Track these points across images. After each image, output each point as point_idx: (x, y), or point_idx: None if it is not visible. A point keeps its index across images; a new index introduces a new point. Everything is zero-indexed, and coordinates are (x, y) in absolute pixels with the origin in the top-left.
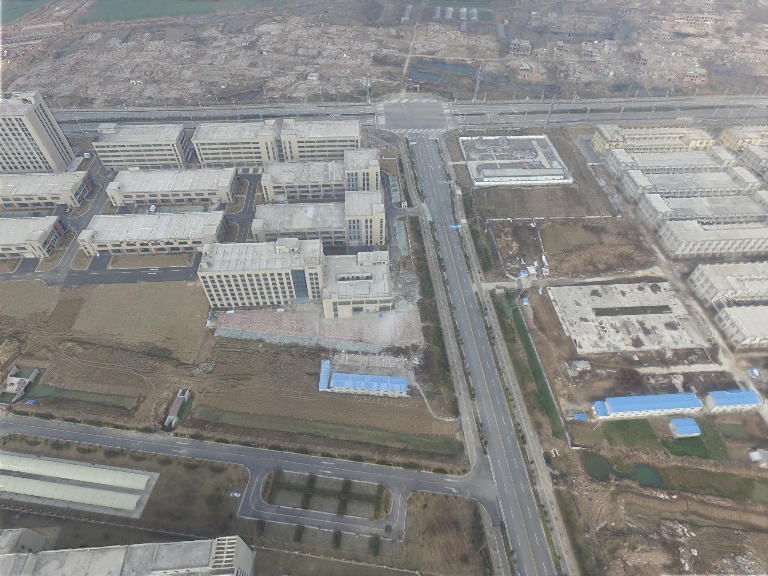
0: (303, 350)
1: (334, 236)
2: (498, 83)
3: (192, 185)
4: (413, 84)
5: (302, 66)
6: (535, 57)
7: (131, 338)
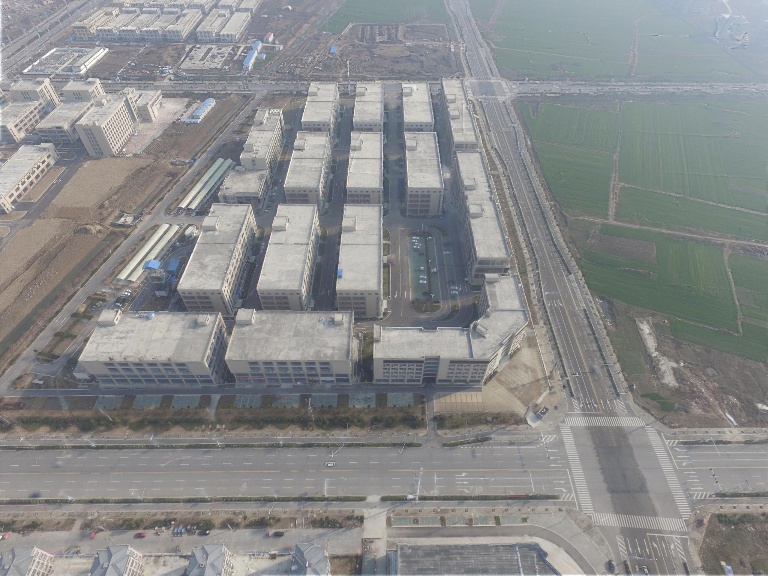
0: None
1: None
2: None
3: None
4: None
5: None
6: None
7: (118, 182)
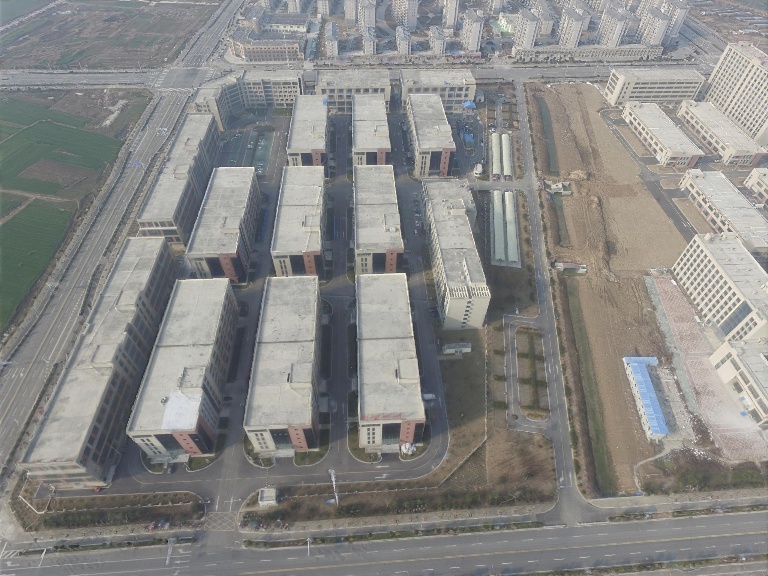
0: (660, 342)
1: None
2: None
3: None
4: None
5: None
6: None
7: (616, 229)
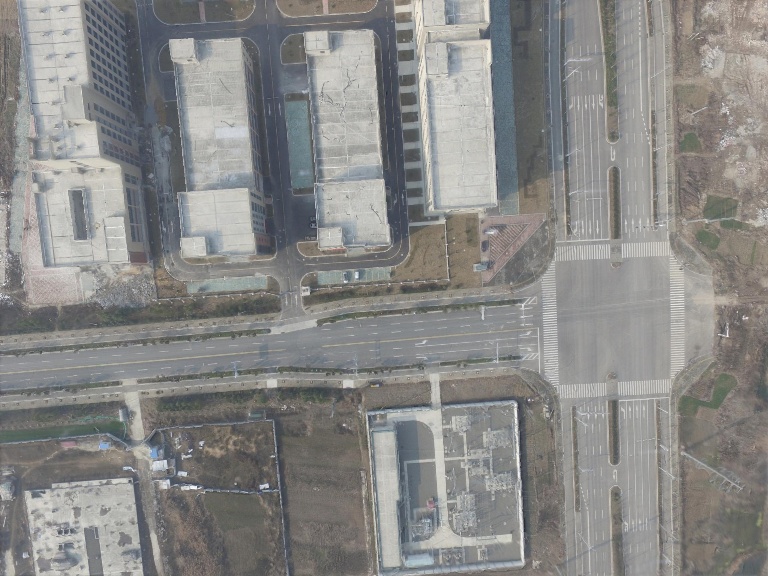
0: (7, 155)
1: None
2: (766, 512)
3: None
4: (762, 323)
5: None
6: None
7: None
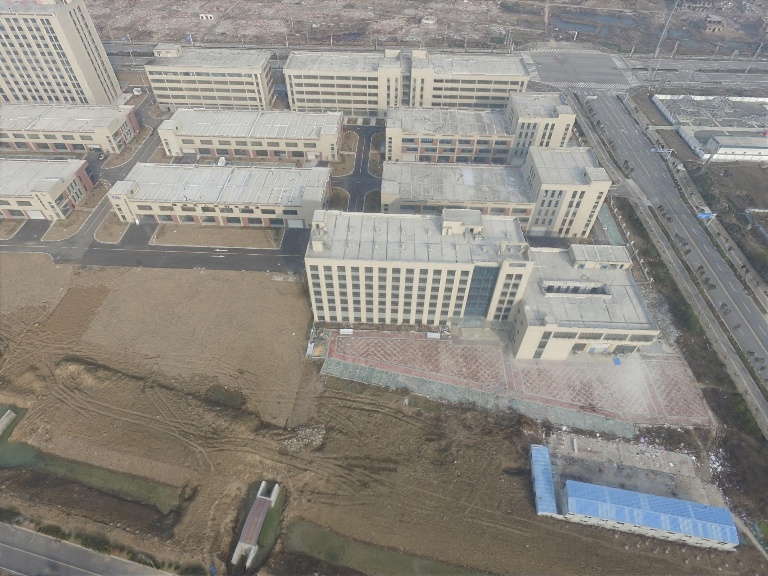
0: (487, 418)
1: None
2: (678, 37)
3: (281, 131)
4: (562, 33)
5: (412, 9)
6: (718, 11)
7: (178, 365)
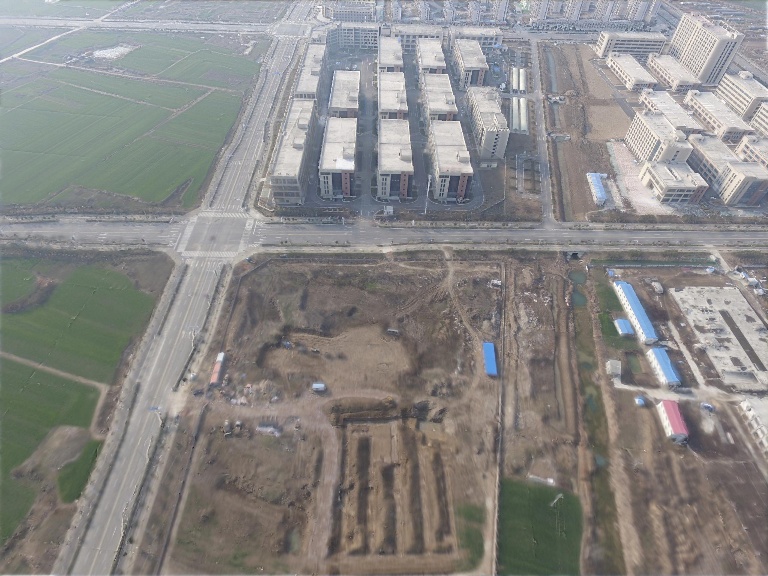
0: (611, 169)
1: (713, 172)
2: None
3: (720, 117)
4: None
5: None
6: None
7: (592, 120)
